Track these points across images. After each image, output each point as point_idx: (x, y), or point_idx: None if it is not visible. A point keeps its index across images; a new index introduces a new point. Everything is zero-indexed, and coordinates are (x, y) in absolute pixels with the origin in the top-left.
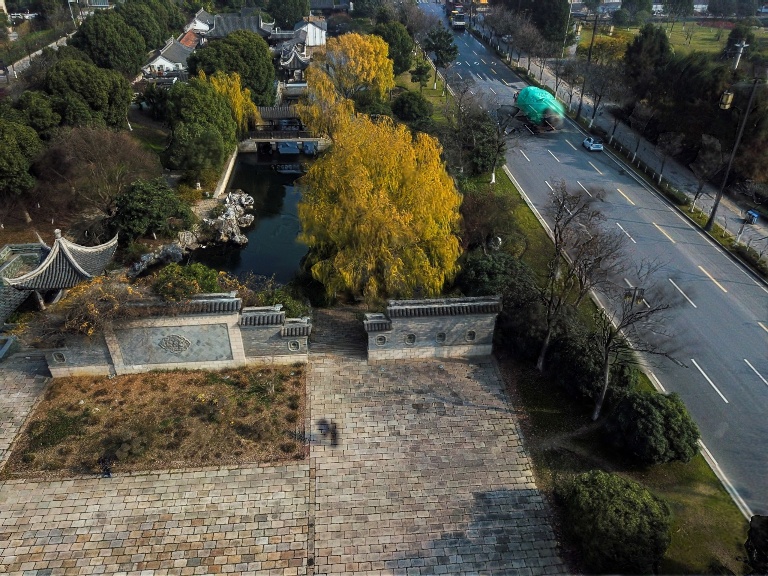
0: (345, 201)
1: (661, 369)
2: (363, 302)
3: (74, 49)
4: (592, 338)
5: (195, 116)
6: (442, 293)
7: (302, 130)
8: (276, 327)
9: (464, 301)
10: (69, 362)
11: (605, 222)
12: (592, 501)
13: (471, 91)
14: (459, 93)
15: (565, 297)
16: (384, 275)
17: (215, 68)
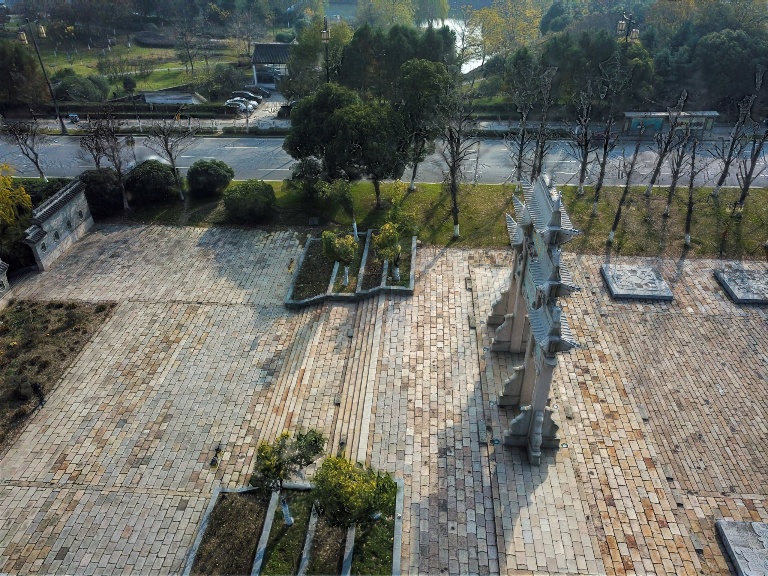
0: None
1: None
2: None
3: None
4: (142, 167)
5: None
6: (35, 205)
7: None
8: None
9: (66, 189)
10: None
11: (7, 158)
12: (241, 193)
13: None
14: None
15: None
16: None
17: None
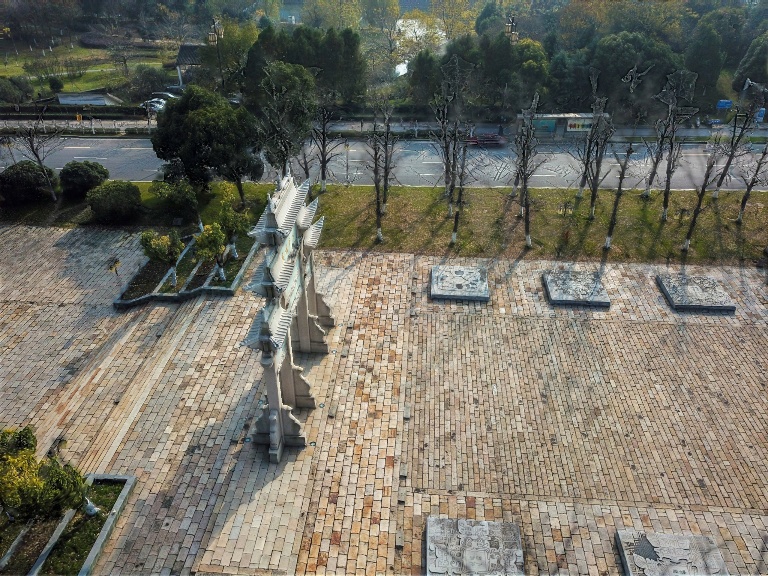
0: None
1: None
2: None
3: None
4: (13, 168)
5: None
6: None
7: None
8: None
9: None
10: None
11: None
12: (102, 194)
13: None
14: None
15: None
16: None
17: None
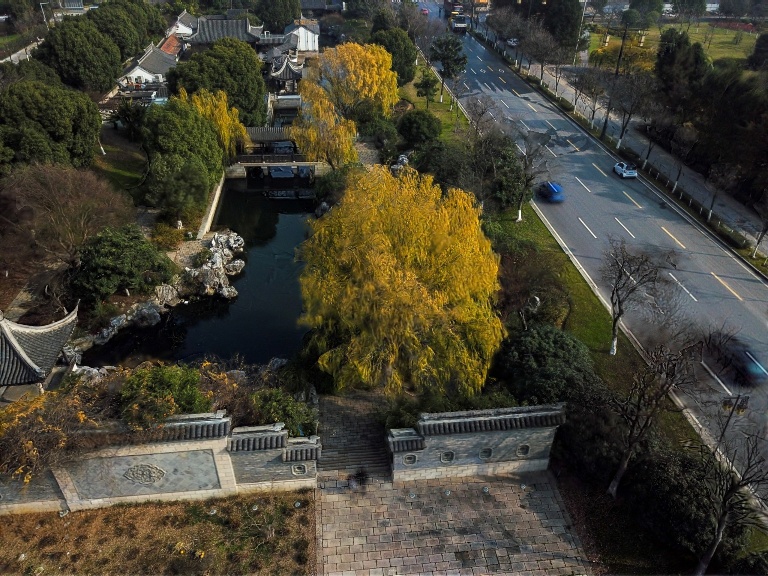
0: (360, 276)
1: None
2: (379, 386)
3: (37, 63)
4: (687, 466)
5: (175, 144)
6: (484, 392)
7: (297, 153)
8: (276, 450)
9: (517, 412)
10: (7, 498)
11: None
12: None
13: (490, 112)
14: (476, 114)
15: (654, 415)
16: (409, 365)
17: (198, 85)
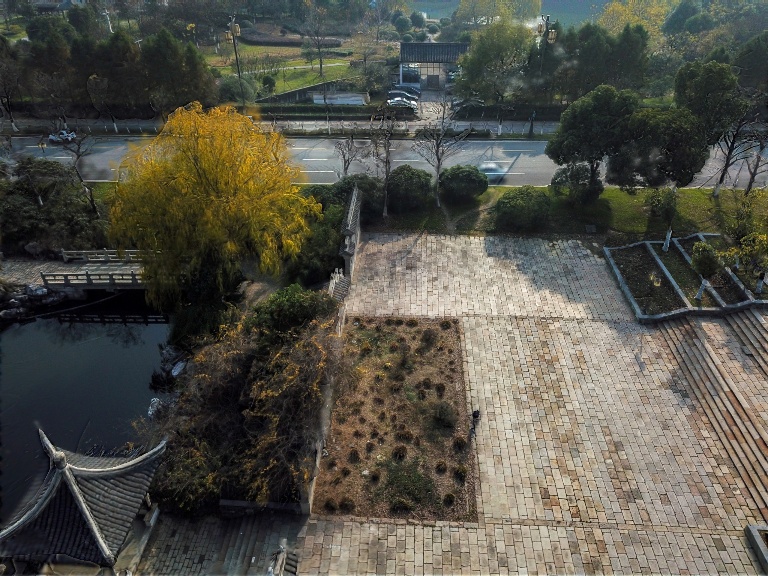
0: None
1: (466, 143)
2: (245, 291)
3: None
4: (400, 172)
5: None
6: None
7: None
8: None
9: None
10: None
11: None
12: (523, 201)
13: None
14: None
15: None
16: None
17: None
